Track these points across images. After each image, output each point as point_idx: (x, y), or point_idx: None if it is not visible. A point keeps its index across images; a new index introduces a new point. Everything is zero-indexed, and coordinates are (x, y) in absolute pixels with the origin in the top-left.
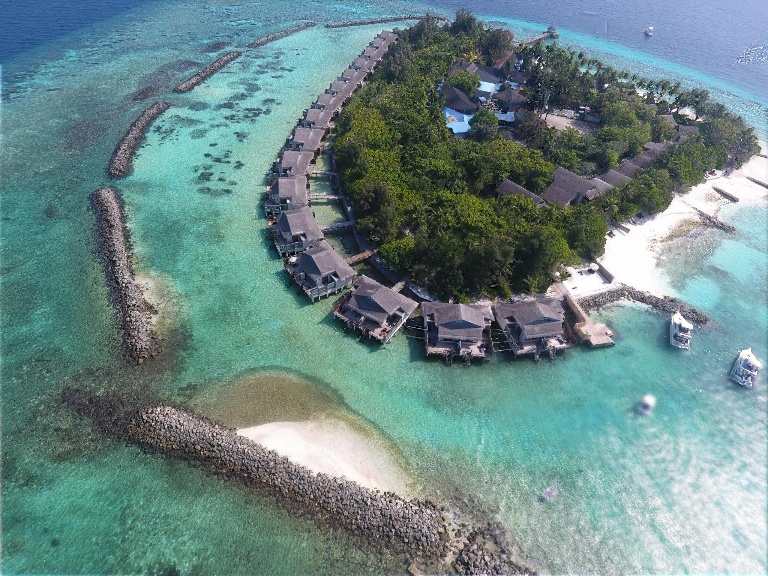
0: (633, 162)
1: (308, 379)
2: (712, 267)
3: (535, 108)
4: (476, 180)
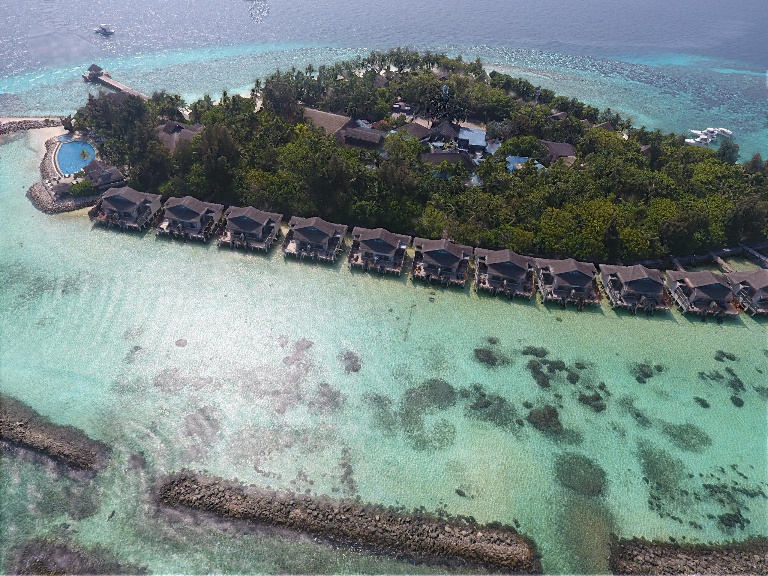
0: None
1: None
2: None
3: (463, 119)
4: None
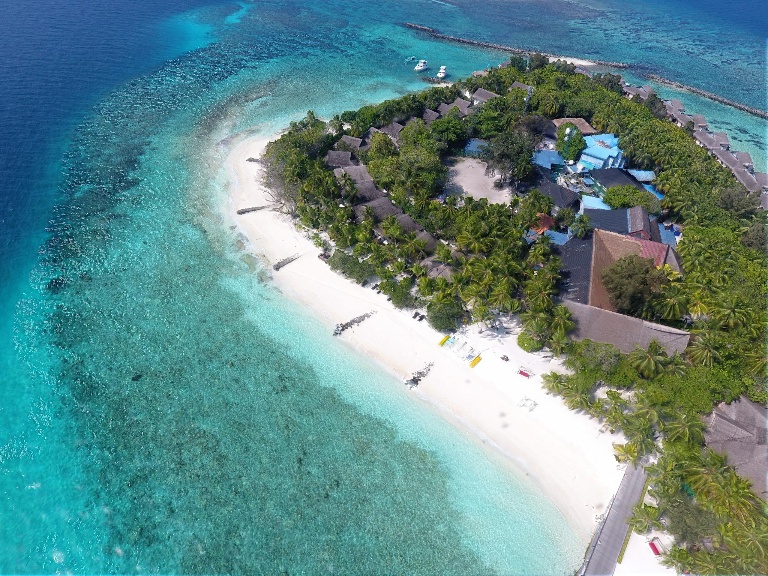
0: (428, 123)
1: None
2: (402, 93)
3: None
4: None
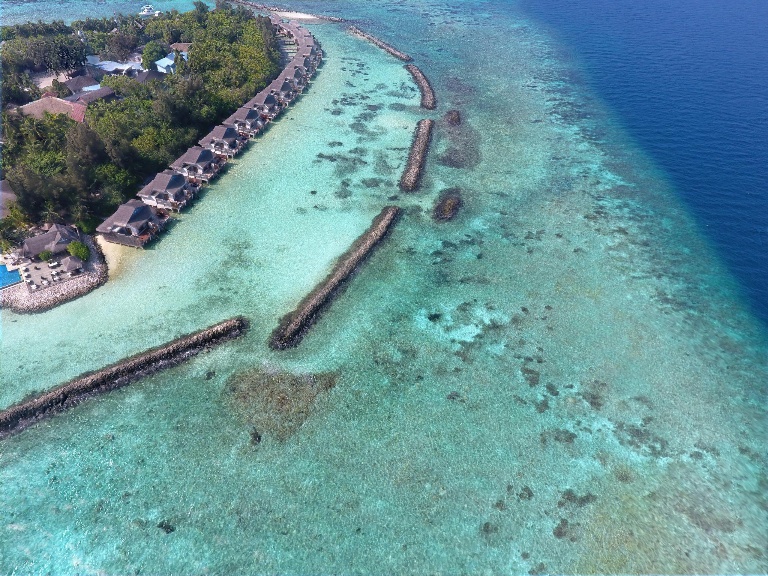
0: None
1: (299, 22)
2: None
3: None
4: (204, 25)
